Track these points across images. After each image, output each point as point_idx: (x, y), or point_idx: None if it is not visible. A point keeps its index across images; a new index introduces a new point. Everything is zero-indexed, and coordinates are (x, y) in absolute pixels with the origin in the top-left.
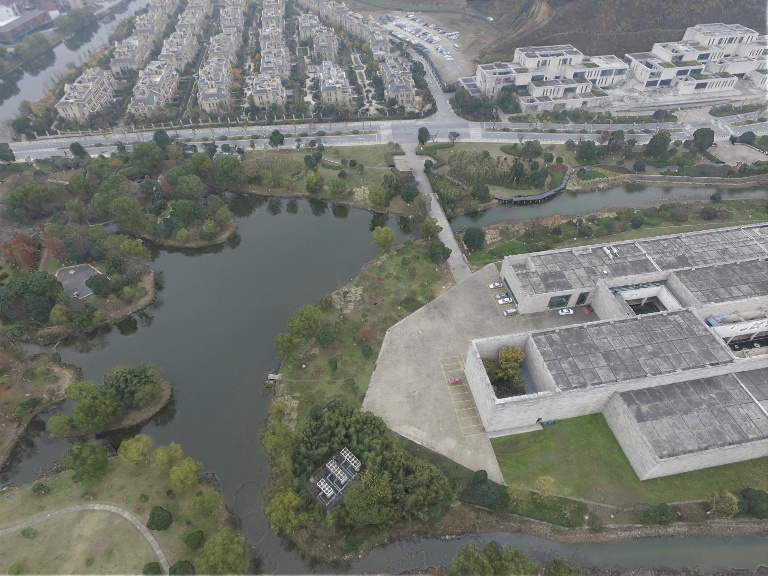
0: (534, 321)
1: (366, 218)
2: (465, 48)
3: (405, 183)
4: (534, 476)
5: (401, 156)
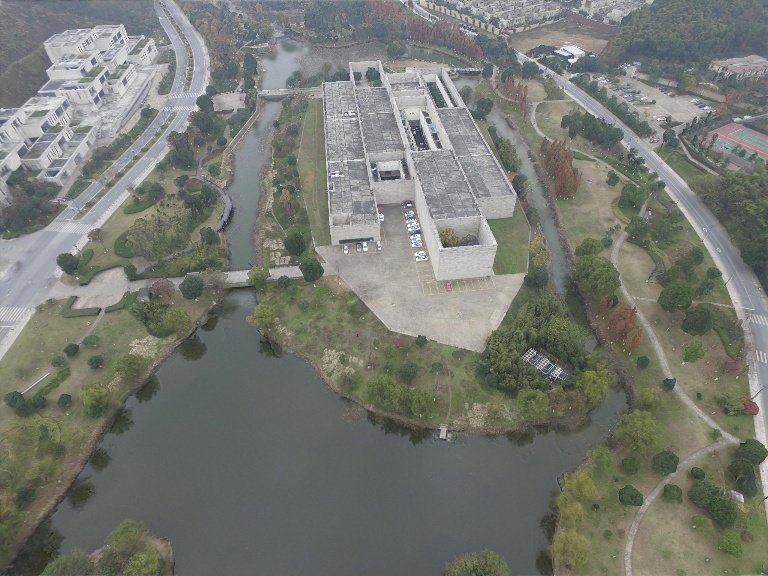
0: (388, 235)
1: (175, 360)
2: None
3: (168, 290)
4: (519, 258)
5: (79, 301)
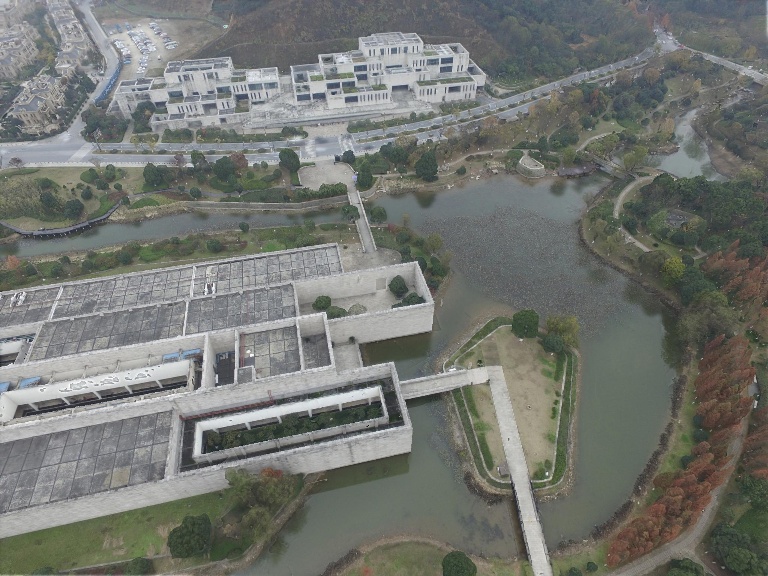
0: None
1: None
2: (168, 59)
3: None
4: None
5: None
